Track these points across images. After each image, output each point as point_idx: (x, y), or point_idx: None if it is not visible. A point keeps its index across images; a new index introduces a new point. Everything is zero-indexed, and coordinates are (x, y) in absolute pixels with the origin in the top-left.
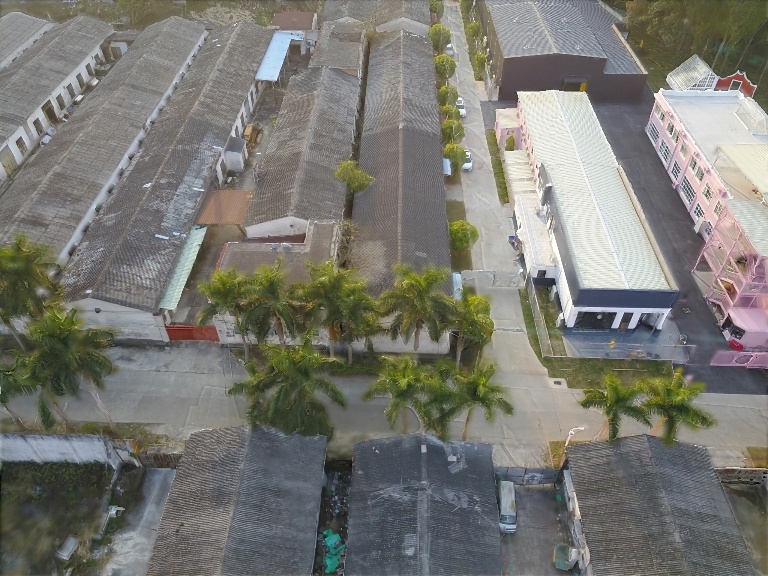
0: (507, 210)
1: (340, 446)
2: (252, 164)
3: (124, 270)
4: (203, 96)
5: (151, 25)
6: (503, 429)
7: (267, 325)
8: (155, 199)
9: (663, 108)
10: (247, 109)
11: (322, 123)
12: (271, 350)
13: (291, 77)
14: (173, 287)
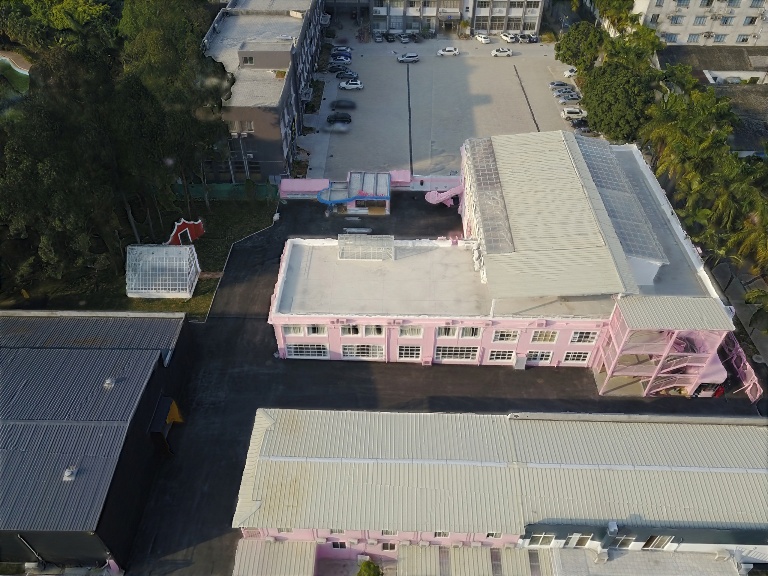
0: None
1: None
2: None
3: None
4: None
5: None
6: None
7: None
8: None
9: (313, 323)
10: None
11: None
12: None
13: None
14: None
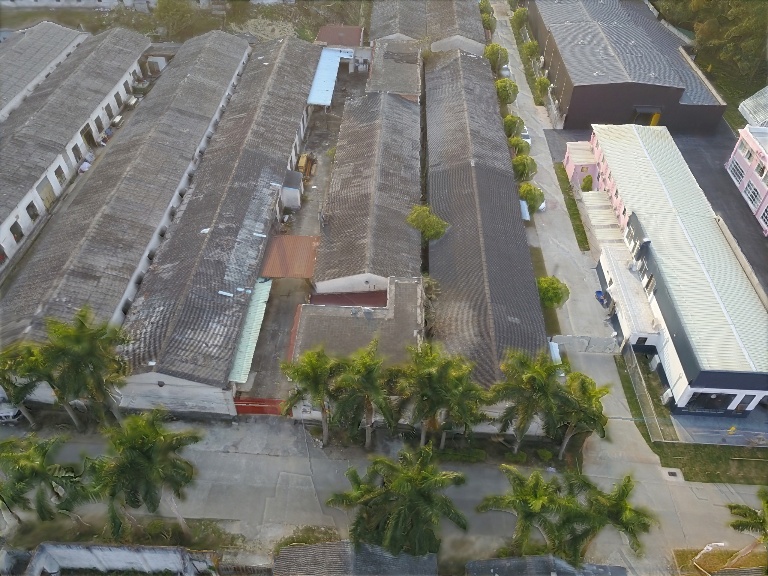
0: (589, 259)
1: (439, 552)
2: (308, 200)
3: (188, 336)
4: (256, 124)
5: (191, 39)
6: (620, 532)
7: (361, 415)
8: (215, 248)
9: (751, 147)
10: (299, 136)
11: (388, 159)
12: (384, 464)
13: (346, 102)
14: (242, 355)
